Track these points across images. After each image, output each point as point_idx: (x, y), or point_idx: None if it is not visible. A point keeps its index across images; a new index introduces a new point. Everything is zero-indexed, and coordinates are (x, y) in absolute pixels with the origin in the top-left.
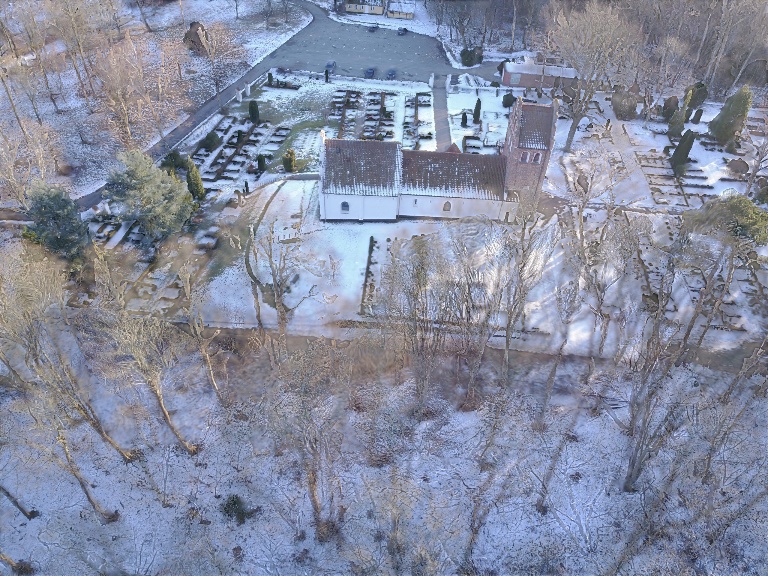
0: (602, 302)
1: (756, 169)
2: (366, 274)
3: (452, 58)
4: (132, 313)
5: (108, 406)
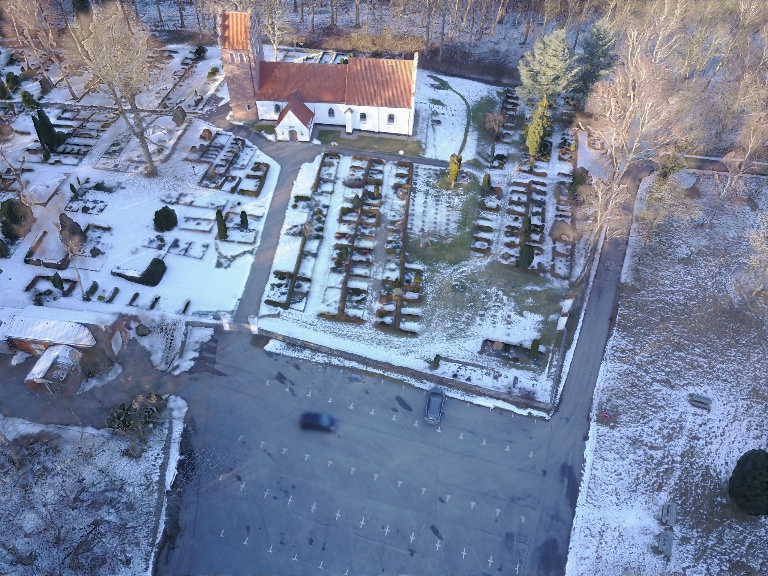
0: None
1: None
2: None
3: (173, 441)
4: None
5: (510, 45)
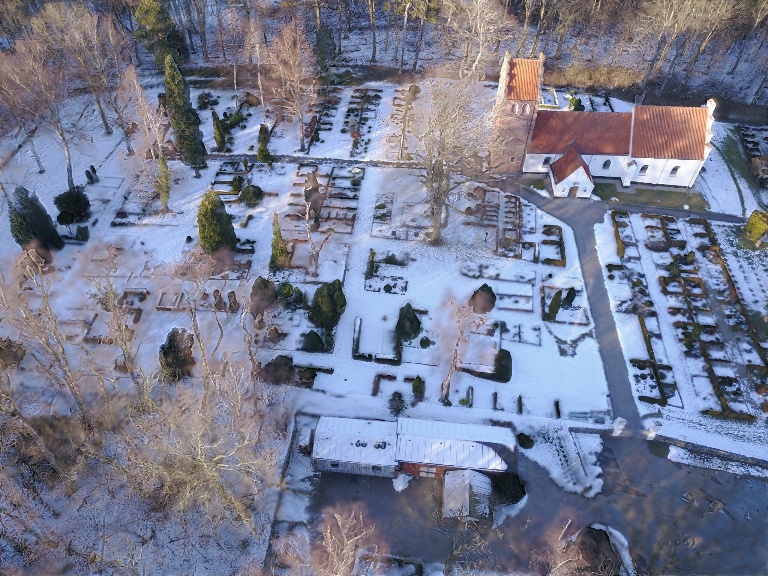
0: None
1: None
2: None
3: None
4: (765, 130)
5: None
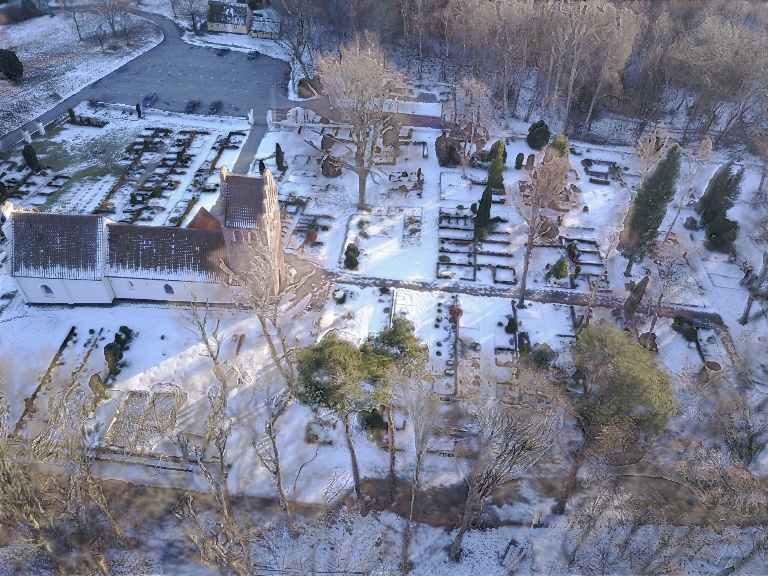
0: (223, 456)
1: (530, 246)
2: (43, 380)
3: (291, 88)
4: None
5: None
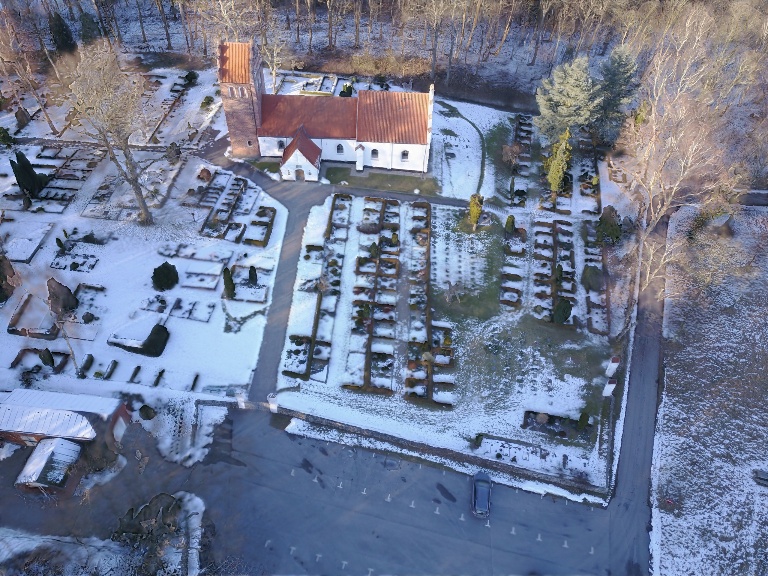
0: None
1: None
2: None
3: (191, 552)
4: None
5: (518, 66)
